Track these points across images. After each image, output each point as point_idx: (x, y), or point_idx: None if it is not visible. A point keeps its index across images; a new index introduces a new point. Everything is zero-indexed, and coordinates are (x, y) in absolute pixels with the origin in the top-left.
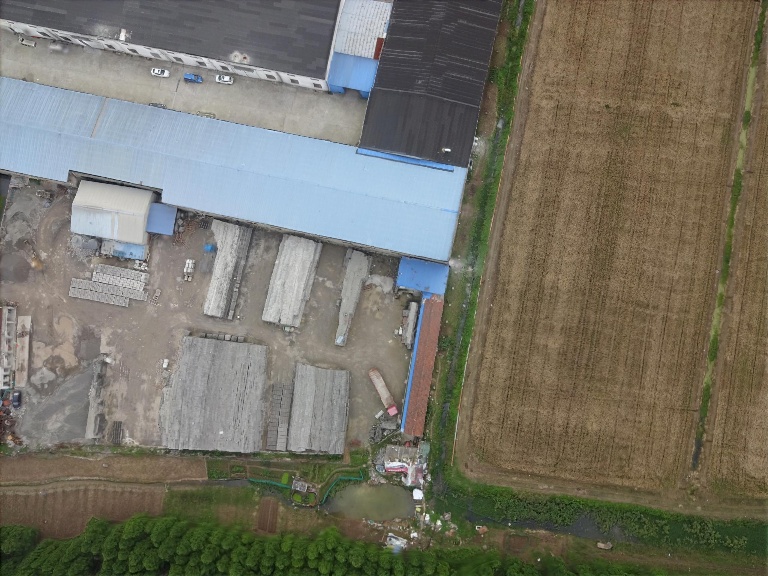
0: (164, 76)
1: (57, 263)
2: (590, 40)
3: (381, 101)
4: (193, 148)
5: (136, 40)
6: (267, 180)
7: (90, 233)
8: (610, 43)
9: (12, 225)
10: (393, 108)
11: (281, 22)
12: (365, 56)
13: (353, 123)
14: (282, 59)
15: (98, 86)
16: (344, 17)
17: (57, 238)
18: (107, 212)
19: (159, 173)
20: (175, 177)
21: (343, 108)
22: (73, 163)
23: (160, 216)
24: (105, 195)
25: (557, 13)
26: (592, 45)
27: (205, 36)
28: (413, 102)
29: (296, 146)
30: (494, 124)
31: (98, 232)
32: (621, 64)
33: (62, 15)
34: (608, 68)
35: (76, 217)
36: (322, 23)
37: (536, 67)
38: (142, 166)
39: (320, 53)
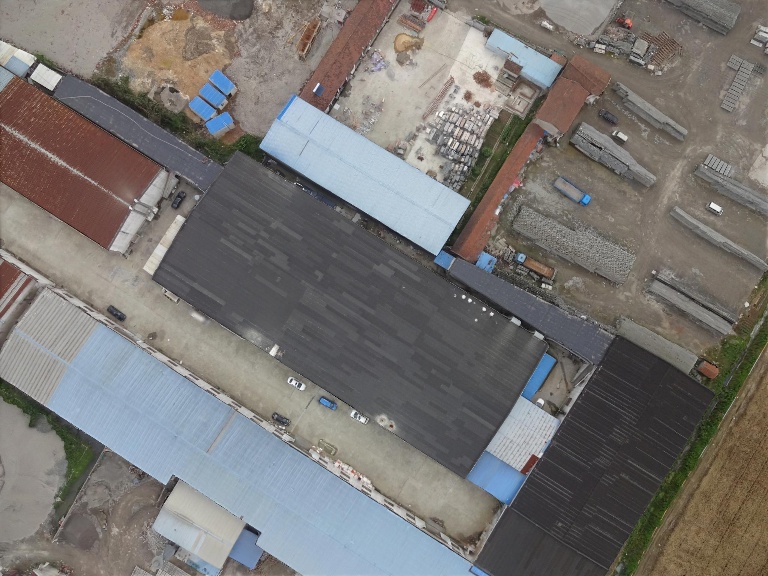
0: (299, 389)
1: (126, 543)
2: (741, 521)
3: (513, 525)
4: (307, 504)
5: (286, 361)
6: (371, 568)
7: (171, 538)
8: (759, 532)
9: (93, 489)
10: (523, 539)
11: (442, 406)
12: (513, 466)
13: (473, 513)
14: (429, 442)
15: (228, 371)
16: (507, 420)
17: (134, 517)
18: (196, 528)
19: (264, 516)
20: (278, 527)
21: (469, 493)
22: (179, 470)
23: (248, 546)
24: (200, 506)
25: (718, 479)
26: (741, 527)
27: (359, 387)
28: (546, 543)
29: (412, 541)
30: (614, 569)
31: (180, 540)
32: (762, 558)
33: (219, 304)
34: (748, 557)
35: (163, 518)
36: (483, 425)
37: (677, 527)
38: (249, 502)
39: (470, 452)
